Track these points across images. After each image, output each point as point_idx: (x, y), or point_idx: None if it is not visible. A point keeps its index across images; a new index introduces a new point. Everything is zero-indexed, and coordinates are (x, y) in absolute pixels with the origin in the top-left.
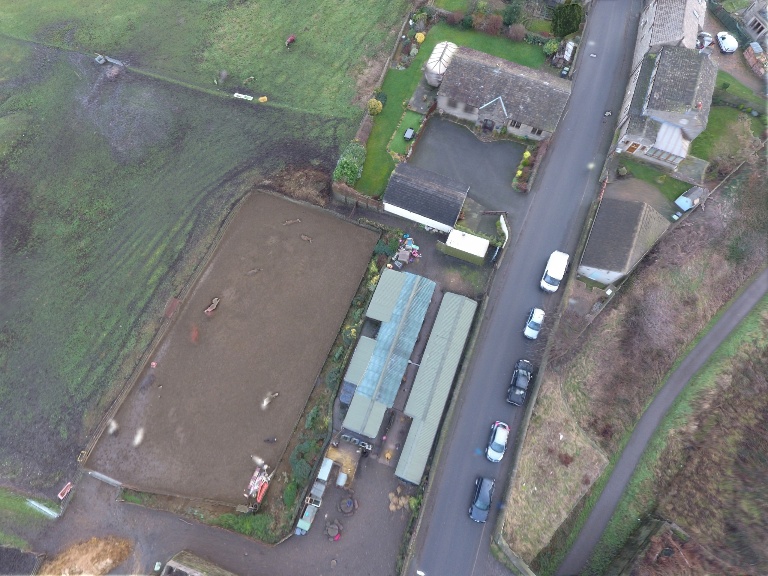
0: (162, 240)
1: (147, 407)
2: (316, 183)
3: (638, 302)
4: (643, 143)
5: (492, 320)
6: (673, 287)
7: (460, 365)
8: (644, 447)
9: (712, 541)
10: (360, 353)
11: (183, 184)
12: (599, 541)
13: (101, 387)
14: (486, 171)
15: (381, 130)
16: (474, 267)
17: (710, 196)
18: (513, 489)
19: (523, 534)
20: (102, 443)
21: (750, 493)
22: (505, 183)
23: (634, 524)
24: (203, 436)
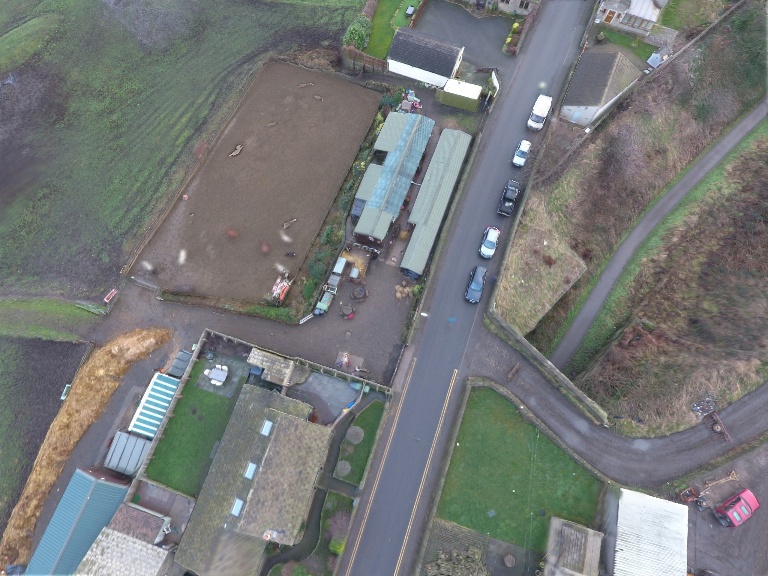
0: (187, 110)
1: (180, 231)
2: (327, 56)
3: (613, 137)
4: (618, 10)
5: (485, 153)
6: (645, 135)
7: (457, 185)
8: (620, 272)
9: (677, 332)
10: (369, 176)
11: (205, 67)
12: (580, 344)
13: (137, 223)
14: (479, 40)
15: (385, 9)
16: (469, 114)
17: (678, 57)
18: (503, 279)
19: (512, 318)
20: (142, 258)
21: (711, 296)
22: (496, 49)
23: (610, 331)
24: (231, 252)
